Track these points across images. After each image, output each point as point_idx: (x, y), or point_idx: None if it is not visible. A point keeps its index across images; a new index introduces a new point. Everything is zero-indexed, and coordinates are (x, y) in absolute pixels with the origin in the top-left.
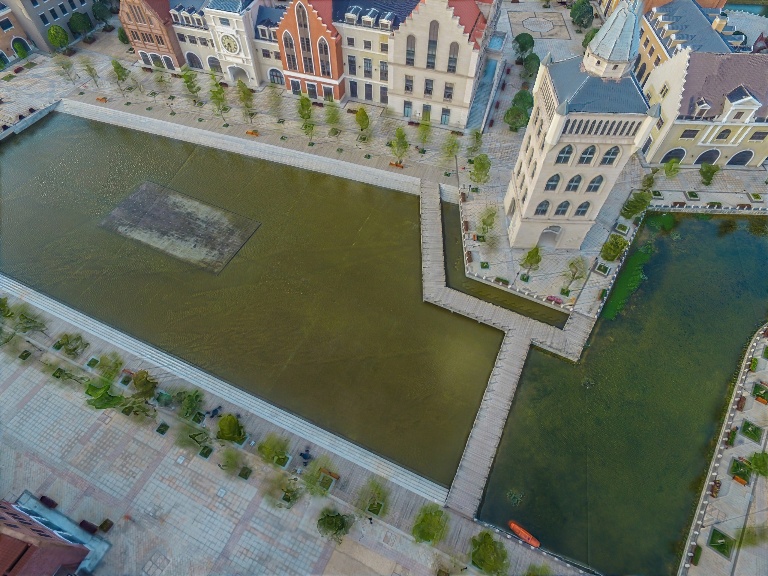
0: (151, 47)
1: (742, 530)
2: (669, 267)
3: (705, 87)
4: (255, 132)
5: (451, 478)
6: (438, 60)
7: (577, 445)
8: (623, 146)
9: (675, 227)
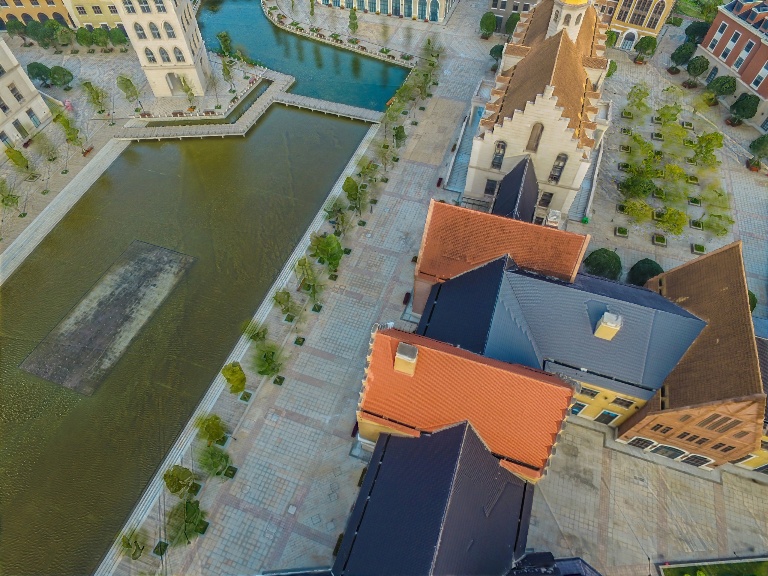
0: None
1: (379, 46)
2: (231, 45)
3: None
4: None
5: (366, 125)
6: None
7: (344, 85)
8: None
9: None
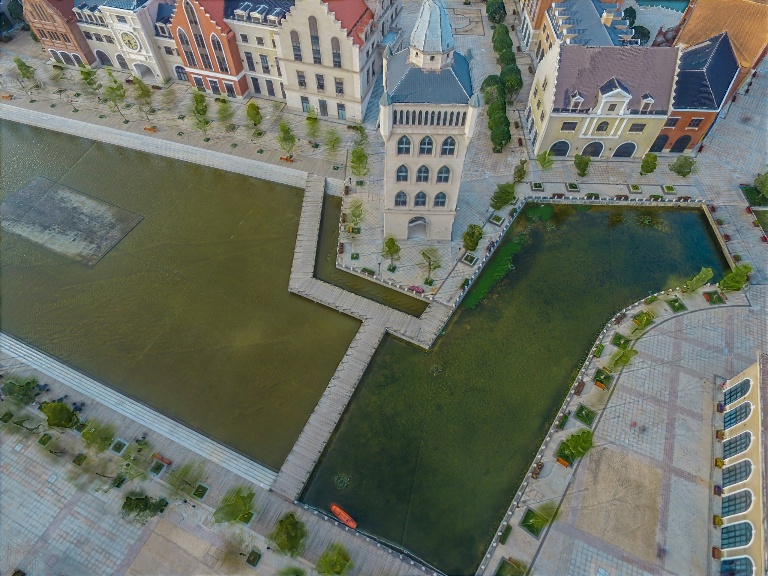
0: (59, 45)
1: (556, 510)
2: (539, 257)
3: (578, 80)
4: (153, 128)
5: None
6: (323, 55)
7: (414, 430)
8: (456, 136)
9: (552, 218)
